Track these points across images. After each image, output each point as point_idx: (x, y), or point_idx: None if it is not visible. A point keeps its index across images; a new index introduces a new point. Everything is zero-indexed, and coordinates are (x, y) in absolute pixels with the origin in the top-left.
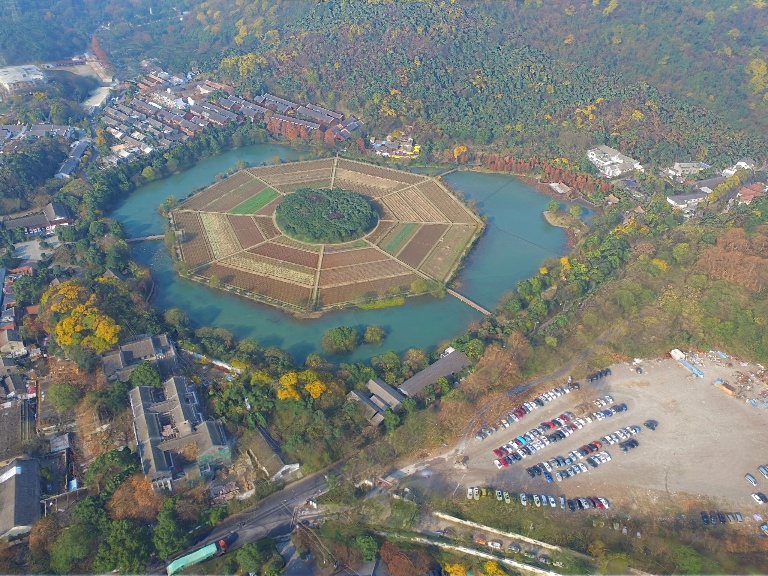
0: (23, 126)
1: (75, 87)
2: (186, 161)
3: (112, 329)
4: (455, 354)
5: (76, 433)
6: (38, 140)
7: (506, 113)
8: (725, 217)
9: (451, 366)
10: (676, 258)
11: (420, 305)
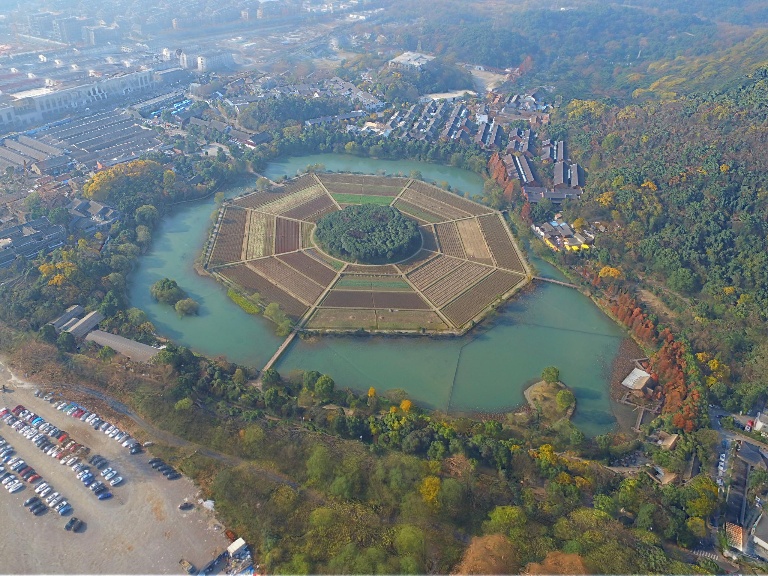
0: (361, 91)
1: (438, 81)
2: (393, 153)
3: (95, 186)
4: (156, 351)
5: (19, 221)
6: (333, 97)
7: (764, 277)
8: (675, 567)
9: (136, 352)
10: (492, 518)
11: (255, 323)
